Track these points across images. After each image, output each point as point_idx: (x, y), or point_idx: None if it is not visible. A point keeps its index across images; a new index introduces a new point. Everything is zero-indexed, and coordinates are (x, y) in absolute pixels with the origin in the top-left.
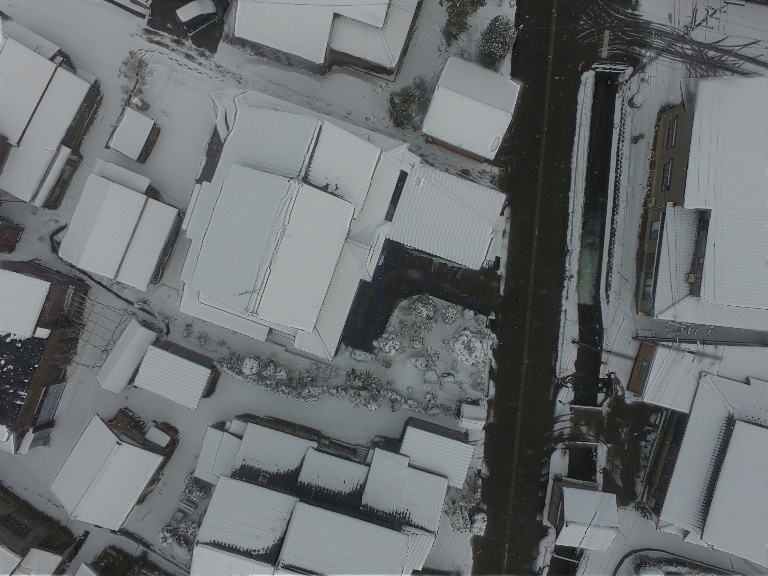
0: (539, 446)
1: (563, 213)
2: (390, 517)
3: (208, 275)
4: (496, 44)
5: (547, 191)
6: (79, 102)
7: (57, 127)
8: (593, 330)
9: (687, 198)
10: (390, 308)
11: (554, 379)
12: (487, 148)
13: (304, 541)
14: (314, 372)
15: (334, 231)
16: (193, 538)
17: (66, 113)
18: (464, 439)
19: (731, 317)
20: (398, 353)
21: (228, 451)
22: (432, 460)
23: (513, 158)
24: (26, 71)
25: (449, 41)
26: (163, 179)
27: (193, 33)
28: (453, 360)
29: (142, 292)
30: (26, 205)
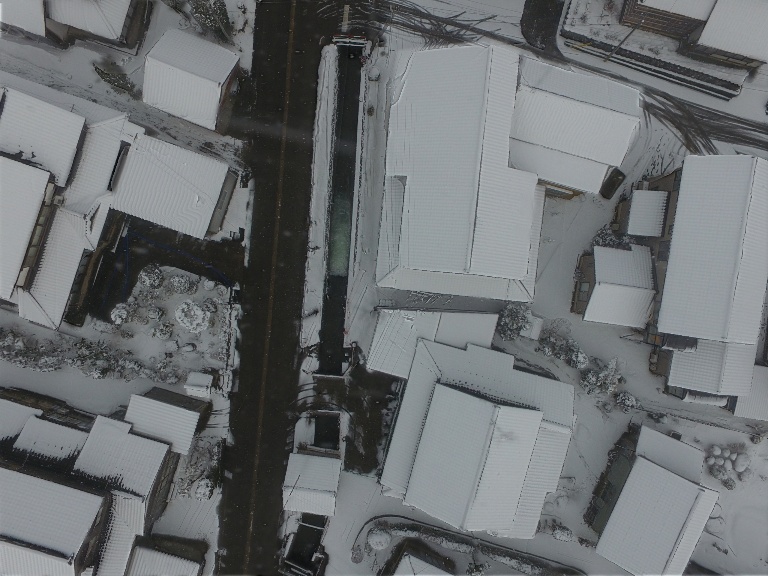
0: (284, 415)
1: (305, 185)
2: (101, 482)
3: None
4: (198, 14)
5: (290, 163)
6: None
7: None
8: (340, 301)
9: (388, 166)
10: (136, 280)
11: (298, 349)
12: (212, 119)
13: None
14: (57, 343)
15: (26, 198)
16: None
17: None
18: (197, 407)
19: (448, 284)
20: (141, 324)
21: None
22: (157, 427)
23: (256, 131)
24: None
25: None
26: None
27: None
28: None
29: None
30: None
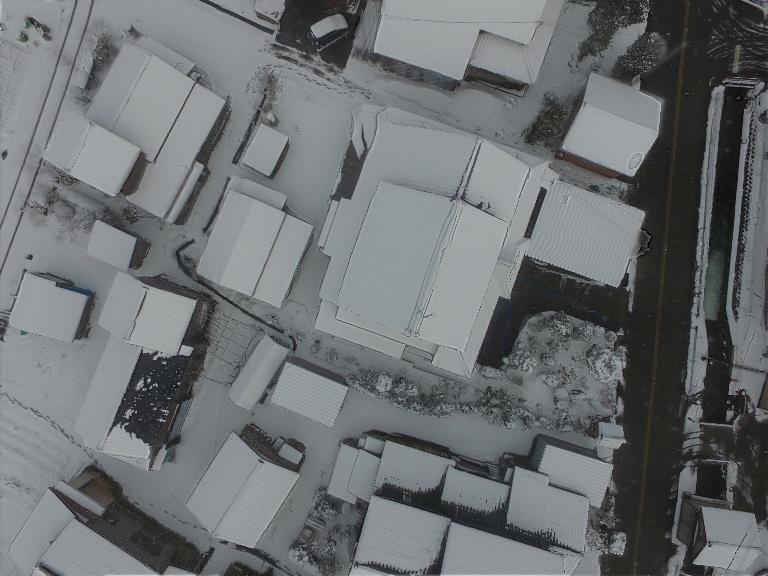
0: (668, 464)
1: (693, 229)
2: (536, 537)
3: (358, 294)
4: (646, 62)
5: (676, 207)
6: (214, 118)
7: (192, 143)
8: (720, 347)
9: None
10: (518, 324)
11: (683, 396)
12: (625, 165)
13: (462, 562)
14: (443, 389)
15: (489, 250)
16: (320, 555)
17: (201, 129)
18: None
19: None
20: None
21: (365, 469)
22: (571, 479)
23: (642, 174)
24: (167, 88)
25: (583, 57)
26: (292, 195)
27: (322, 48)
28: (582, 377)
29: (270, 308)
30: (153, 220)
